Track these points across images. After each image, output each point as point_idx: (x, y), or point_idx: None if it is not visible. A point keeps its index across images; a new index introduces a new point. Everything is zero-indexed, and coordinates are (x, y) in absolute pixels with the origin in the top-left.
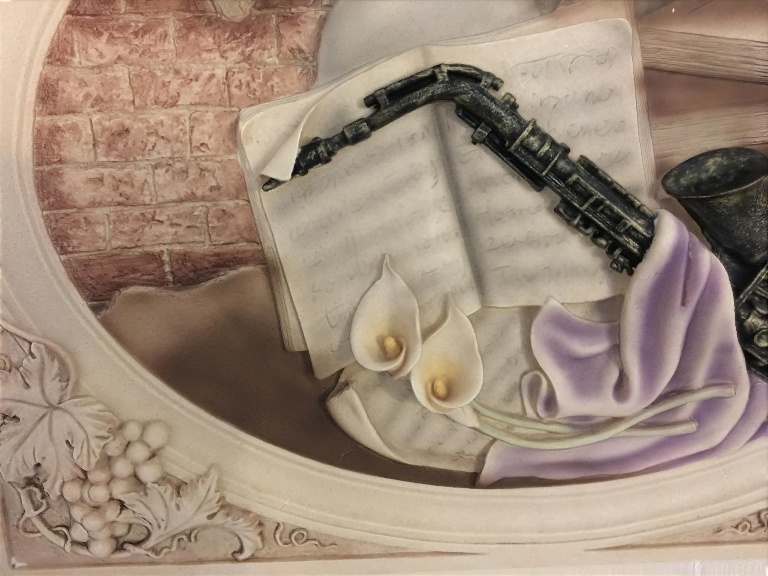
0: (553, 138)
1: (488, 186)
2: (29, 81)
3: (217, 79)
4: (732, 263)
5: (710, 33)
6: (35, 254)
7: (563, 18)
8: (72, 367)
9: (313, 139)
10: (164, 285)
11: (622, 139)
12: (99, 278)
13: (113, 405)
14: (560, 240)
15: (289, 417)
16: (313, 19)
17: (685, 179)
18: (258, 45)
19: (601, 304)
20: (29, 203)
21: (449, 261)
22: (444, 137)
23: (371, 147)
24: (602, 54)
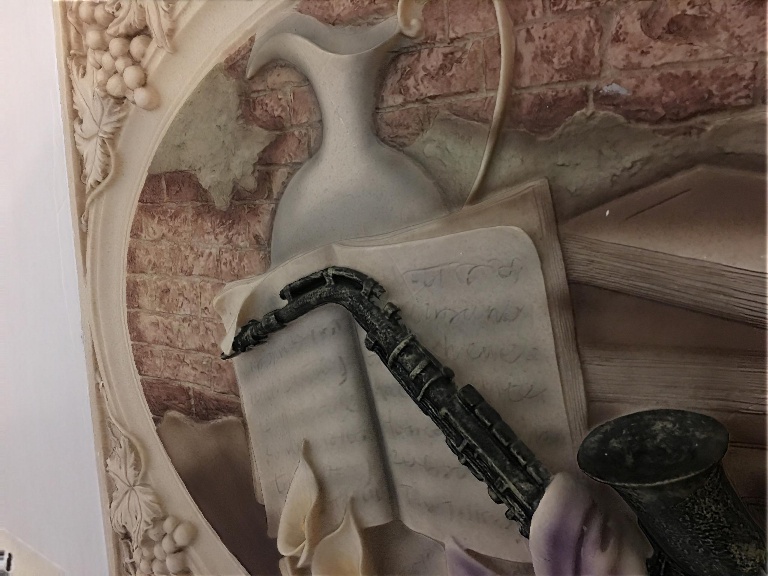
0: (438, 358)
1: (388, 395)
2: (125, 248)
3: (213, 256)
4: None
5: (655, 247)
6: (131, 370)
7: (457, 222)
8: (143, 461)
9: (248, 322)
10: (190, 415)
11: (536, 370)
12: (157, 398)
13: (165, 499)
14: (462, 475)
15: (261, 560)
16: (268, 211)
17: (619, 441)
18: (236, 231)
19: None
20: (127, 333)
21: (353, 464)
22: None
23: (294, 335)
24: (505, 265)
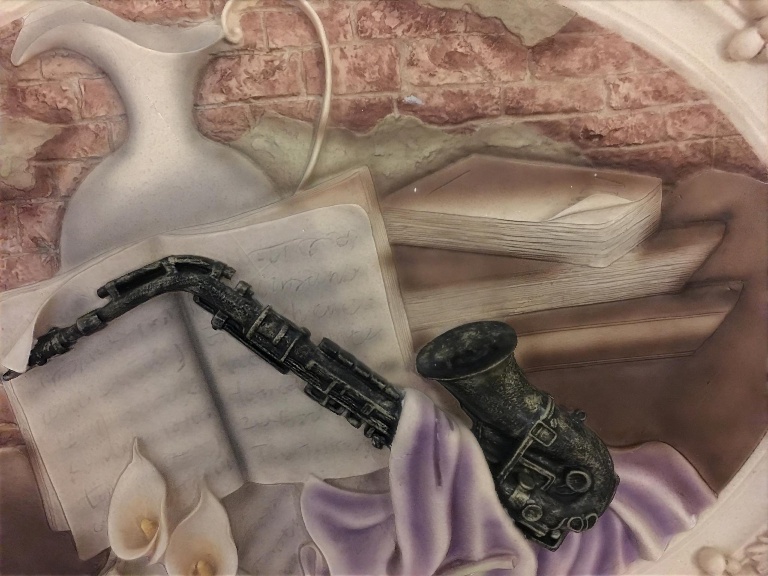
0: (293, 322)
1: (236, 368)
2: None
3: None
4: (496, 436)
5: (452, 212)
6: None
7: (298, 204)
8: None
9: (49, 330)
10: None
11: (372, 316)
12: None
13: None
14: (316, 418)
15: None
16: (52, 209)
17: (441, 353)
18: None
19: (375, 474)
20: None
21: (201, 443)
22: (191, 319)
23: (113, 333)
24: (342, 236)
